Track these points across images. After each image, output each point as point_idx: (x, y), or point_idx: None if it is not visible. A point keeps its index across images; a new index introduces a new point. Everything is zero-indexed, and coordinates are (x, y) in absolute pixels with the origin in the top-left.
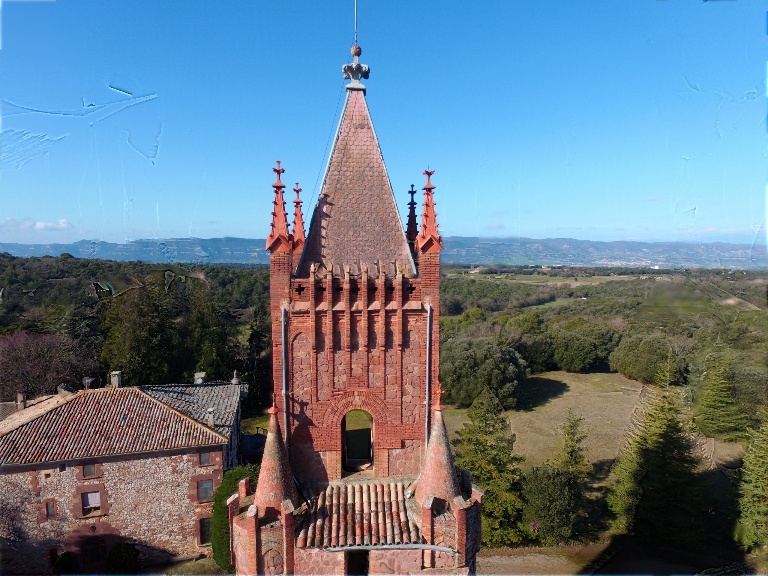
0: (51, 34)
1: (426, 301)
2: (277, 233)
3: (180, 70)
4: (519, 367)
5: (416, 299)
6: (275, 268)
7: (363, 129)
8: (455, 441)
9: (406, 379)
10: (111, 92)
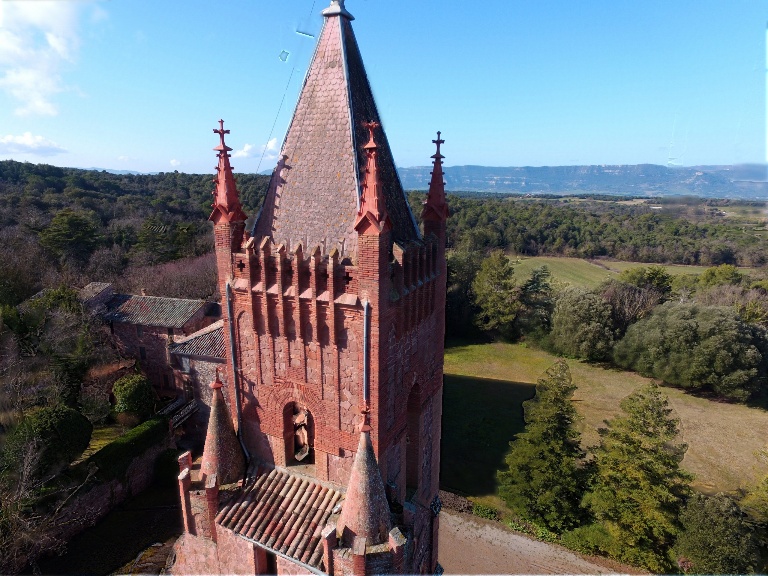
0: (80, 7)
1: (363, 296)
2: (218, 203)
3: (367, 1)
4: (767, 352)
5: (353, 292)
6: (219, 240)
7: (334, 68)
8: (603, 430)
9: (344, 383)
10: (298, 37)
